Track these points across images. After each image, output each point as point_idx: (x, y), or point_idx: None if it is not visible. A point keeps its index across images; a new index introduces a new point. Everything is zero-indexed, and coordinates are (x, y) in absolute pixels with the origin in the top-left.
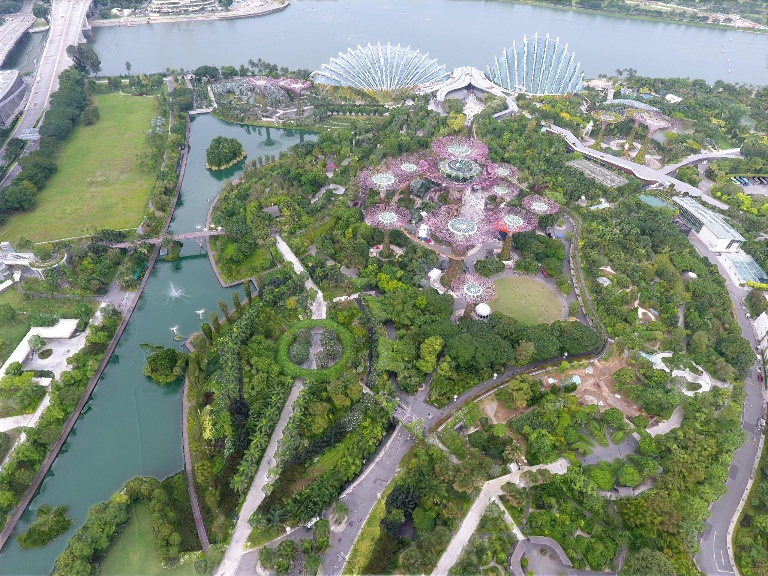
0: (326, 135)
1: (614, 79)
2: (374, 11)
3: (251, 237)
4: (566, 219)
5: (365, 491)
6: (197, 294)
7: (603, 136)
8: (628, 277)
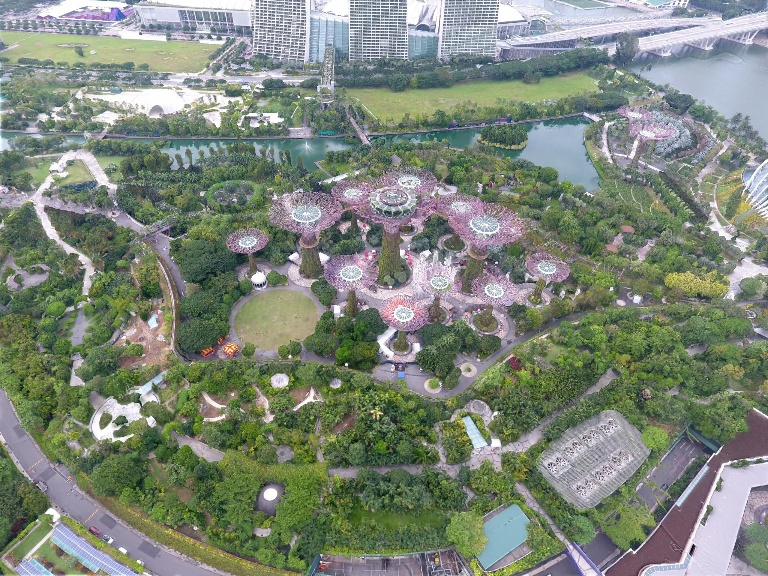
0: (548, 170)
1: None
2: None
3: None
4: None
5: (126, 223)
6: (310, 156)
7: None
8: None
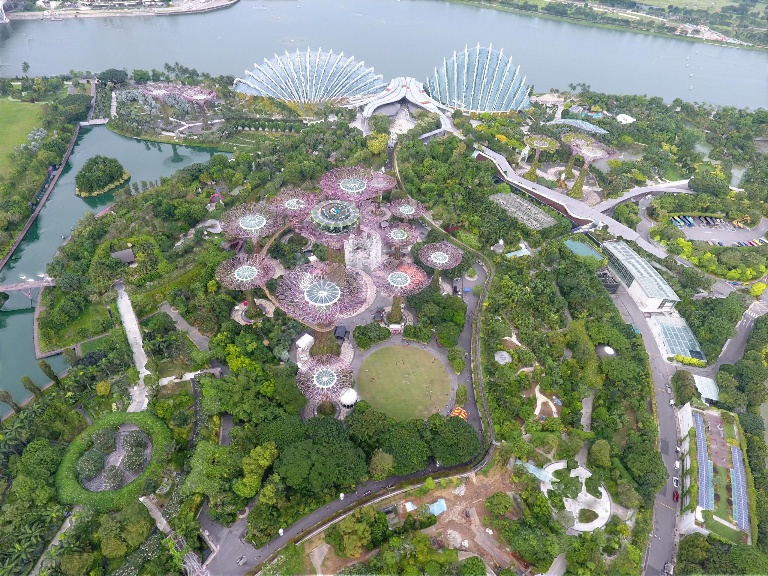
0: (219, 158)
1: (566, 94)
2: (328, 11)
3: (85, 292)
4: (480, 267)
5: None
6: (1, 368)
7: (542, 162)
8: (533, 351)
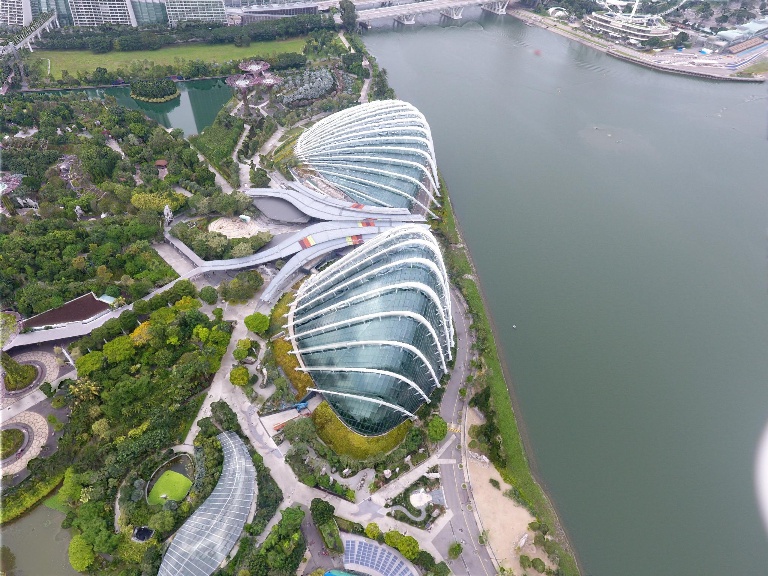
0: (129, 114)
1: None
2: None
3: None
4: None
5: None
6: None
7: None
8: None
